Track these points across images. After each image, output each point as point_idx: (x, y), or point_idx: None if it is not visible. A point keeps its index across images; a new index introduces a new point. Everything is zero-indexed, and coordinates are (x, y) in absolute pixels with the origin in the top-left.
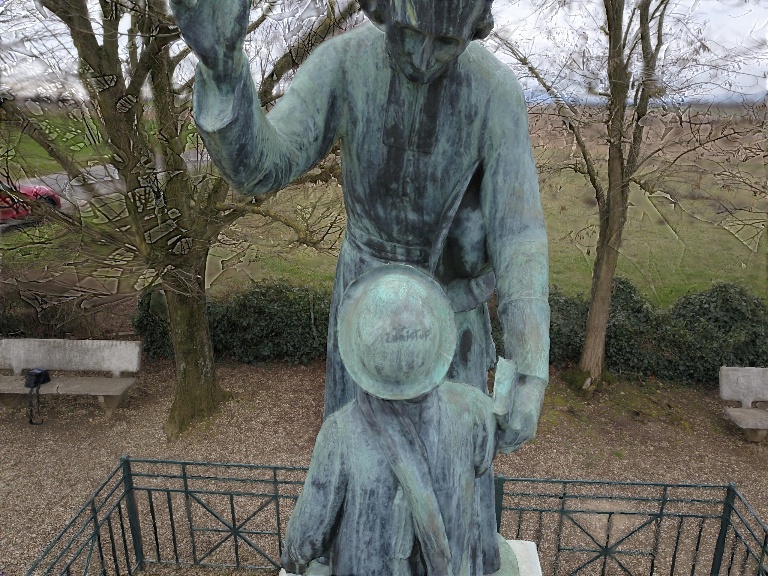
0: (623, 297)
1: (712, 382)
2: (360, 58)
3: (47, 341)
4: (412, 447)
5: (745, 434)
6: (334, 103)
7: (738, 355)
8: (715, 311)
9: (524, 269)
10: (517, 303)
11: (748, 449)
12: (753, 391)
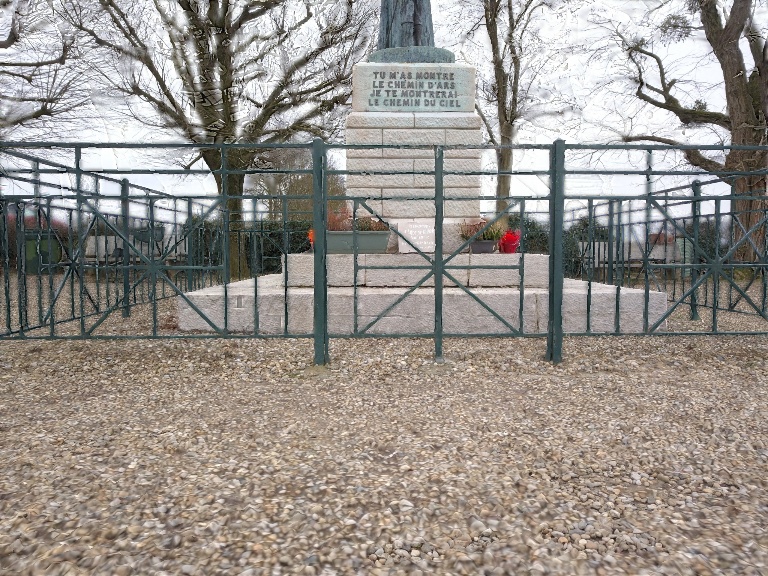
0: None
1: None
2: None
3: None
4: None
5: None
6: None
7: None
8: (579, 231)
9: None
10: None
11: None
12: None
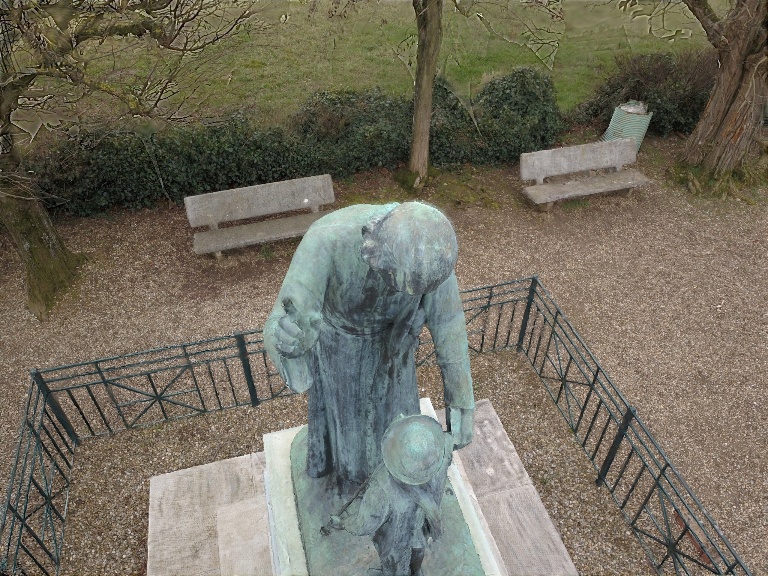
0: (440, 94)
1: (513, 160)
2: (346, 254)
3: None
4: (426, 491)
5: (538, 205)
6: (329, 282)
7: (532, 133)
8: (515, 96)
9: (455, 344)
10: (453, 365)
11: (540, 218)
12: (544, 170)
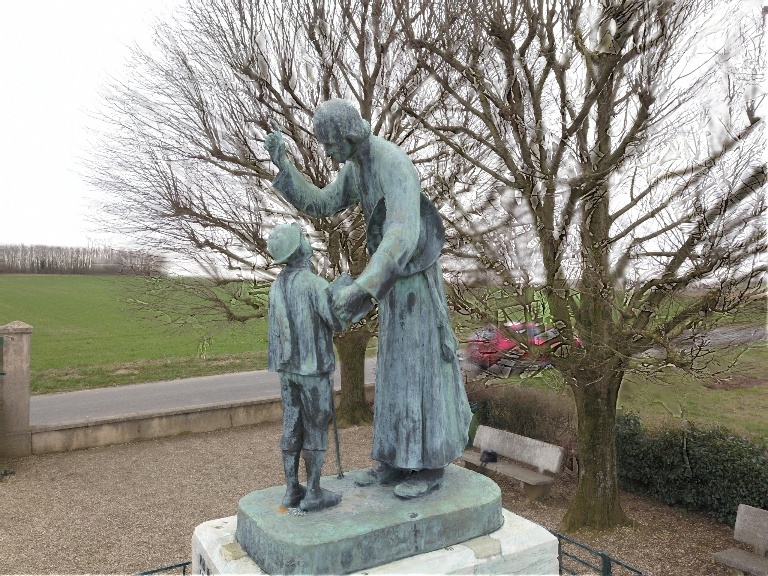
0: None
1: None
2: None
3: (504, 432)
4: (280, 286)
5: None
6: (347, 179)
7: None
8: None
9: (382, 240)
10: None
11: None
12: None
